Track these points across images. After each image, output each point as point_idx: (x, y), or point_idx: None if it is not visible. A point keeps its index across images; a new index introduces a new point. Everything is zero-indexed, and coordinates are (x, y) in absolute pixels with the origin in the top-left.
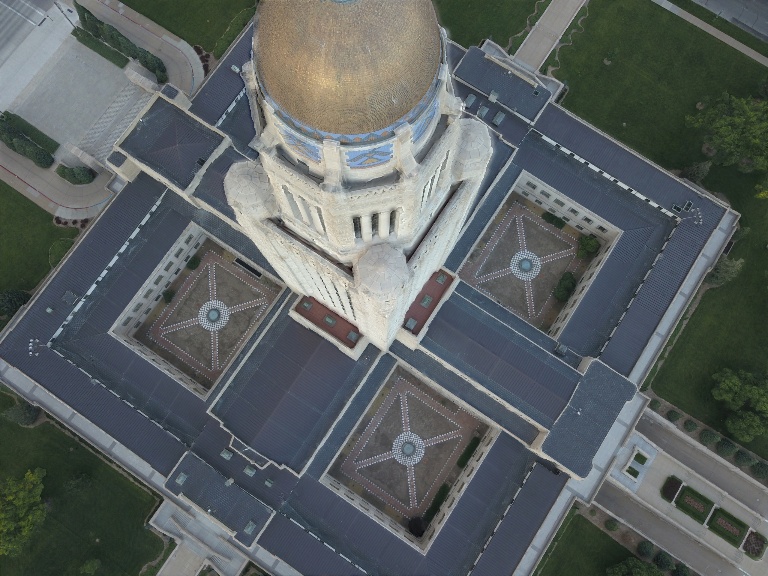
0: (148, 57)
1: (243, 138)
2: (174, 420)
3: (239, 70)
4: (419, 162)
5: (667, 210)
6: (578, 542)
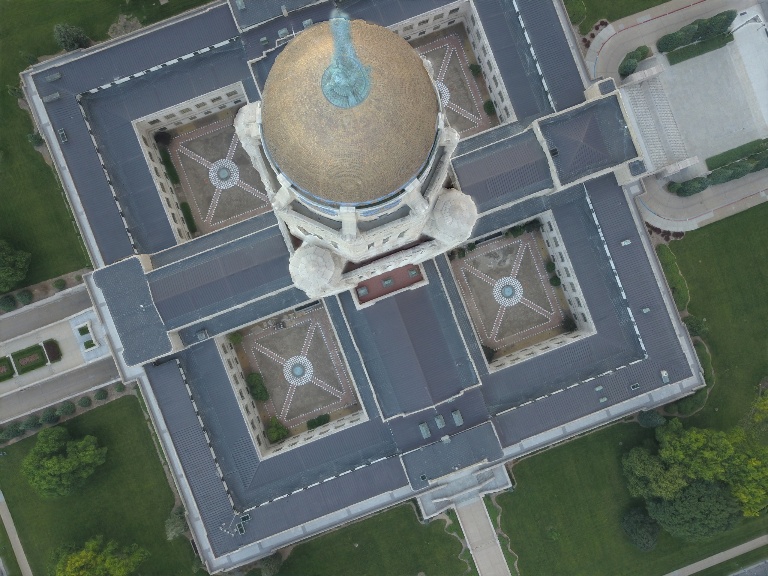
0: (697, 184)
1: (561, 210)
2: (366, 4)
3: (623, 245)
4: (262, 150)
5: (251, 510)
6: (67, 251)
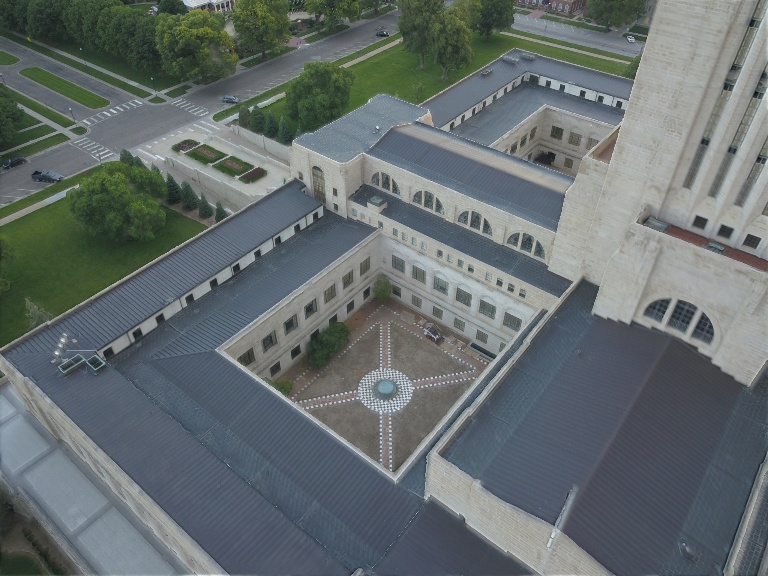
0: None
1: None
2: None
3: None
4: None
5: (114, 369)
6: None
